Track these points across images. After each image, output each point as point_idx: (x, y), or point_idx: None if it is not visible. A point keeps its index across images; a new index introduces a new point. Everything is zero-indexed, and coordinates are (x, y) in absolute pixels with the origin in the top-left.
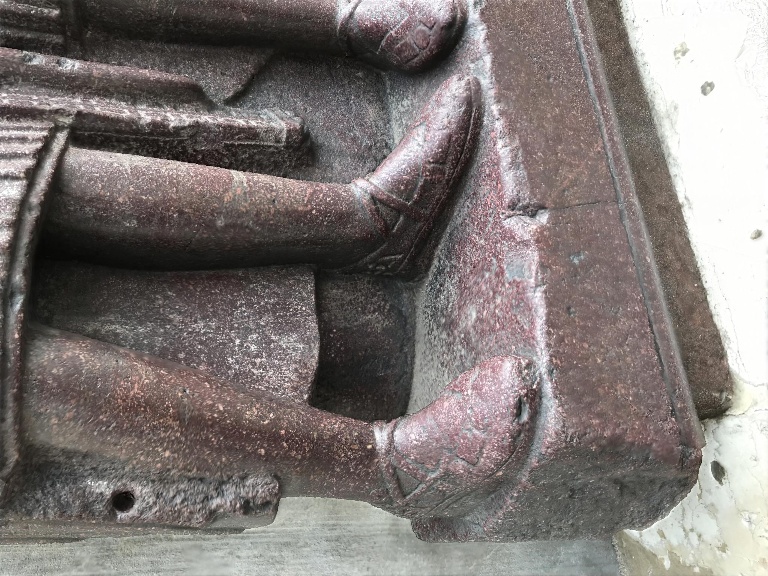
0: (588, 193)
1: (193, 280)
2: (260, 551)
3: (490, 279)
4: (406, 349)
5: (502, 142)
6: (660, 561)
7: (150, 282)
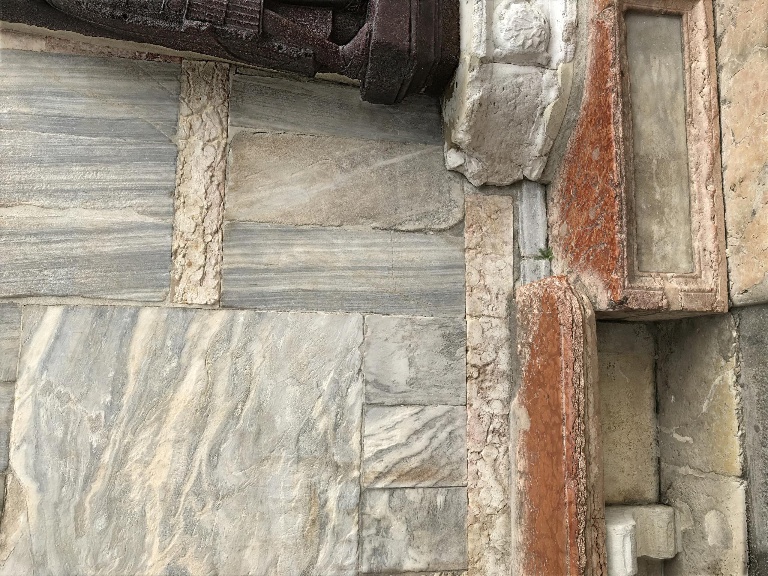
0: None
1: (299, 8)
2: (317, 102)
3: (372, 8)
4: None
5: None
6: None
7: (288, 7)
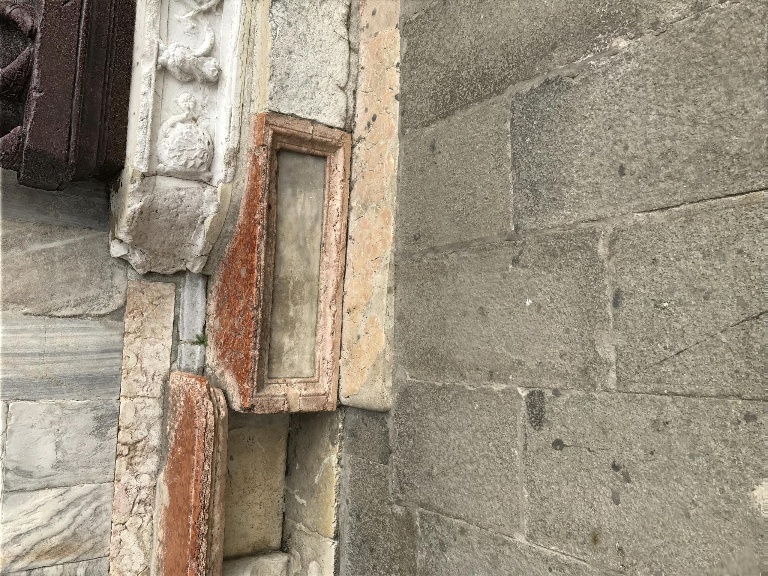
0: (62, 90)
1: None
2: None
3: None
4: (20, 124)
5: (36, 70)
6: (113, 216)
7: None
